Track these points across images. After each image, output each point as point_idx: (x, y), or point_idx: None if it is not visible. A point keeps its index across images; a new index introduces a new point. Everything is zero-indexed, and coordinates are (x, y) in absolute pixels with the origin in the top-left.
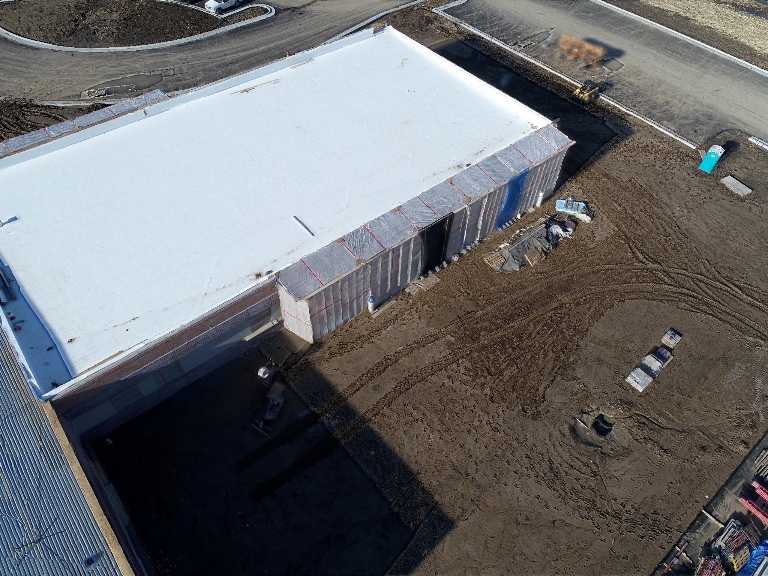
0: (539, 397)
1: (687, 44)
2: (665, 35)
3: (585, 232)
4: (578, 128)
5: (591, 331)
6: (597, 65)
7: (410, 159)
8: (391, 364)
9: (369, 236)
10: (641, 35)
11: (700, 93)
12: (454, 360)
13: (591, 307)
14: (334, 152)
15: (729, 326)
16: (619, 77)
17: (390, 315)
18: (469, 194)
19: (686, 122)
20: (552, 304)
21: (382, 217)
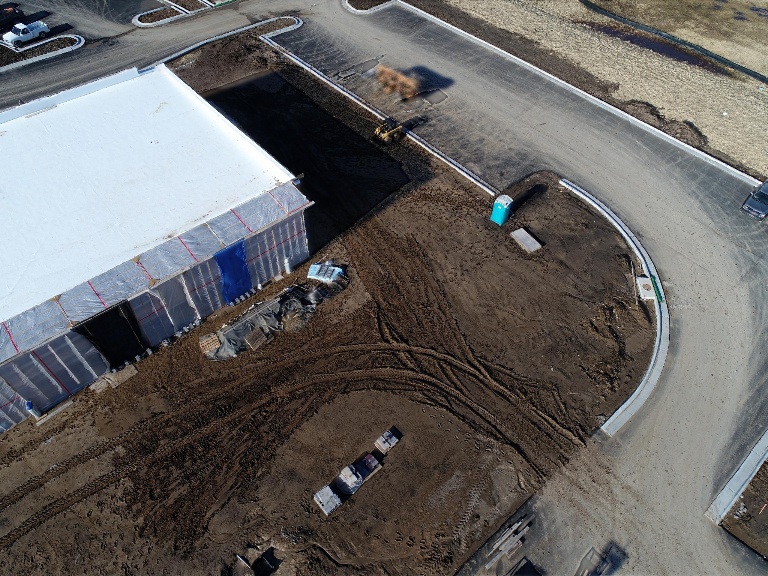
0: (201, 527)
1: (524, 71)
2: (503, 61)
3: (332, 304)
4: (368, 174)
5: (296, 434)
6: (418, 98)
7: (115, 229)
8: (34, 489)
9: (4, 336)
10: (477, 61)
11: (521, 128)
12: (114, 480)
13: (306, 402)
14: (27, 222)
15: (462, 422)
16: (437, 111)
17: (59, 421)
18: (155, 275)
19: (495, 163)
20: (262, 399)
21: (31, 310)
